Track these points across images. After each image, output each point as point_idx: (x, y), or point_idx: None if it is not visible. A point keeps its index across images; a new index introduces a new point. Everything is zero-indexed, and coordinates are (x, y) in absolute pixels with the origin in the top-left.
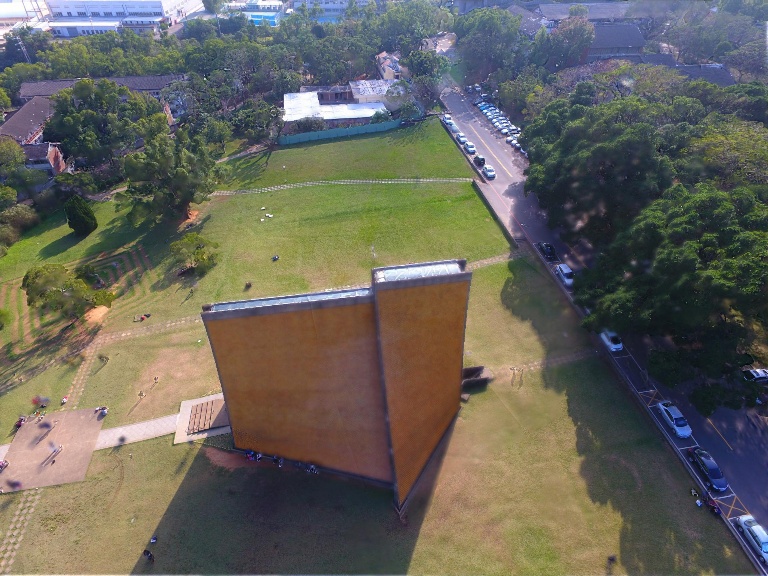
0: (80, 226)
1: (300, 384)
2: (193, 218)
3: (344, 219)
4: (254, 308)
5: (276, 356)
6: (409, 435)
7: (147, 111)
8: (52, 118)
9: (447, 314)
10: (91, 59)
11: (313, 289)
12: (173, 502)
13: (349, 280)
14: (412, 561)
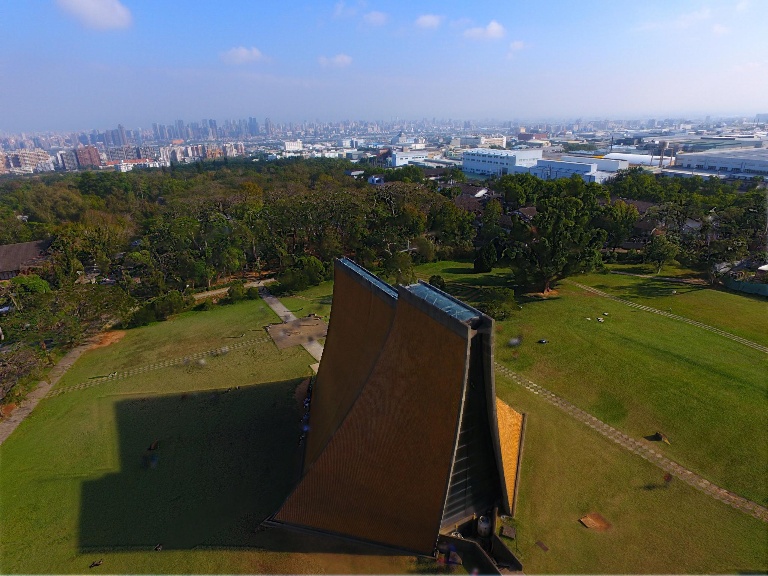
0: (478, 264)
1: (344, 361)
2: (546, 294)
3: (666, 359)
4: (350, 268)
5: (348, 325)
6: (337, 476)
7: (622, 220)
8: (537, 200)
9: (442, 377)
10: (646, 188)
11: (523, 374)
12: (265, 383)
13: (563, 392)
14: (212, 547)
